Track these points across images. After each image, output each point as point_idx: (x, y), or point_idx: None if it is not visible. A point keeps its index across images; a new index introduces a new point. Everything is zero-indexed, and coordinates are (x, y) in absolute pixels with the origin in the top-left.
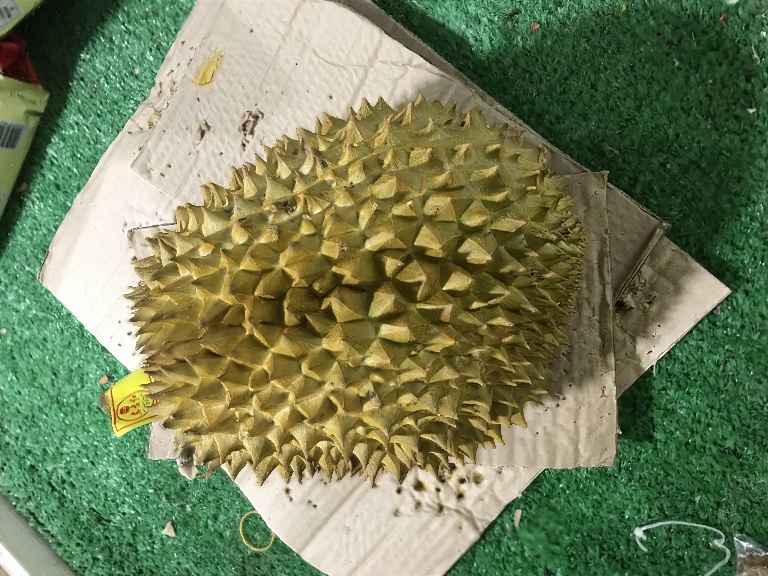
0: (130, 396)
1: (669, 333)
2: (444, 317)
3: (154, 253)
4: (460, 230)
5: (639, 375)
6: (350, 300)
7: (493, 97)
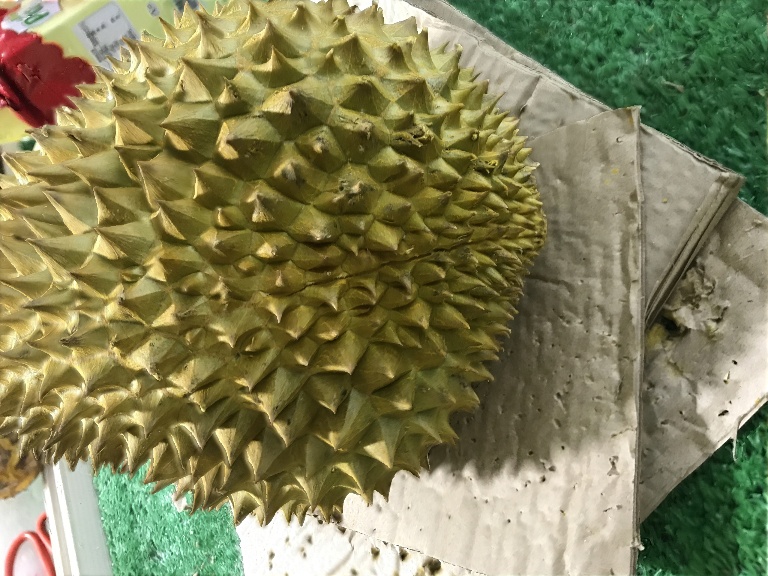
0: None
1: (754, 377)
2: (169, 228)
3: None
4: (217, 112)
5: (706, 455)
6: (73, 202)
7: (523, 51)
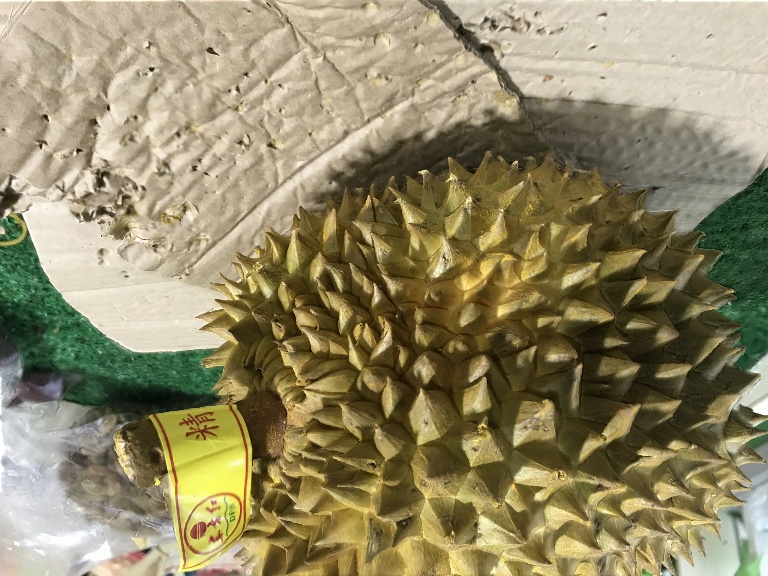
0: (208, 502)
1: None
2: None
3: (476, 501)
4: None
5: None
6: None
7: None
